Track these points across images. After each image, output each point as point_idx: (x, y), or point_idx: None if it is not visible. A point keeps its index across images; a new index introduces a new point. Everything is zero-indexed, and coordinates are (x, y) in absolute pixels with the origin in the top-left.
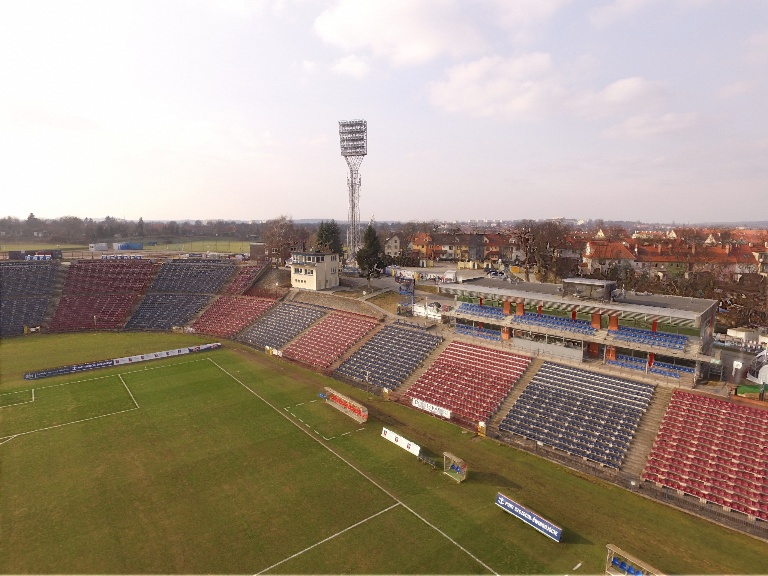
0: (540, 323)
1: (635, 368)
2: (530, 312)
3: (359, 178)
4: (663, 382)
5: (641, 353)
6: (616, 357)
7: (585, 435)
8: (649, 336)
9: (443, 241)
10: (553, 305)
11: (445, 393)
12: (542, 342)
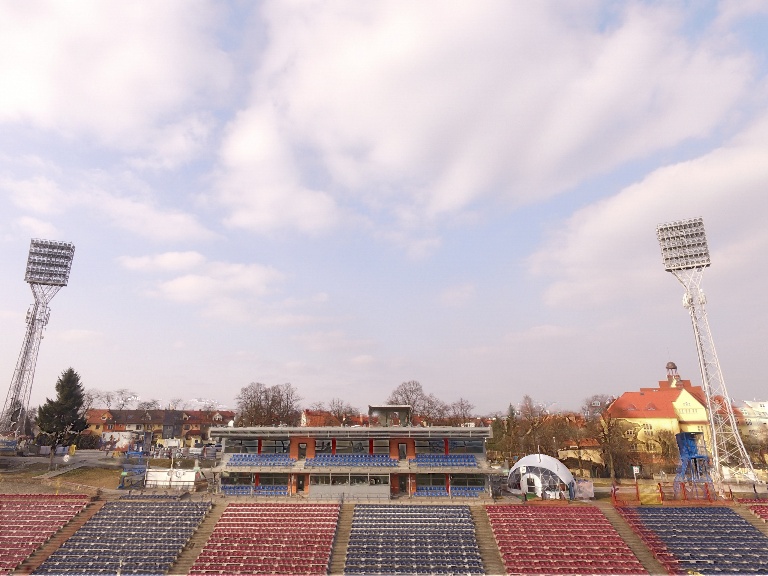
0: (339, 463)
1: (440, 495)
2: (323, 453)
3: (47, 314)
4: (470, 502)
5: (438, 480)
6: (417, 489)
7: (440, 571)
8: (446, 459)
9: (128, 419)
10: (361, 434)
11: (245, 573)
12: (344, 484)
